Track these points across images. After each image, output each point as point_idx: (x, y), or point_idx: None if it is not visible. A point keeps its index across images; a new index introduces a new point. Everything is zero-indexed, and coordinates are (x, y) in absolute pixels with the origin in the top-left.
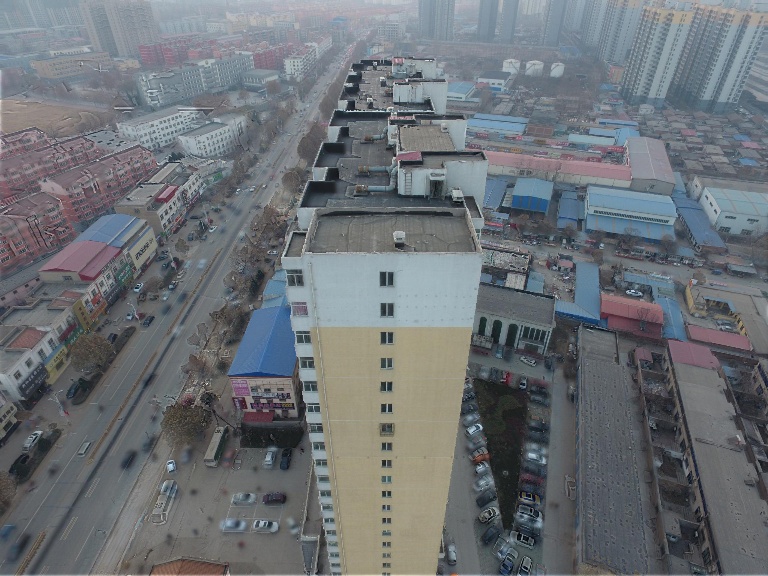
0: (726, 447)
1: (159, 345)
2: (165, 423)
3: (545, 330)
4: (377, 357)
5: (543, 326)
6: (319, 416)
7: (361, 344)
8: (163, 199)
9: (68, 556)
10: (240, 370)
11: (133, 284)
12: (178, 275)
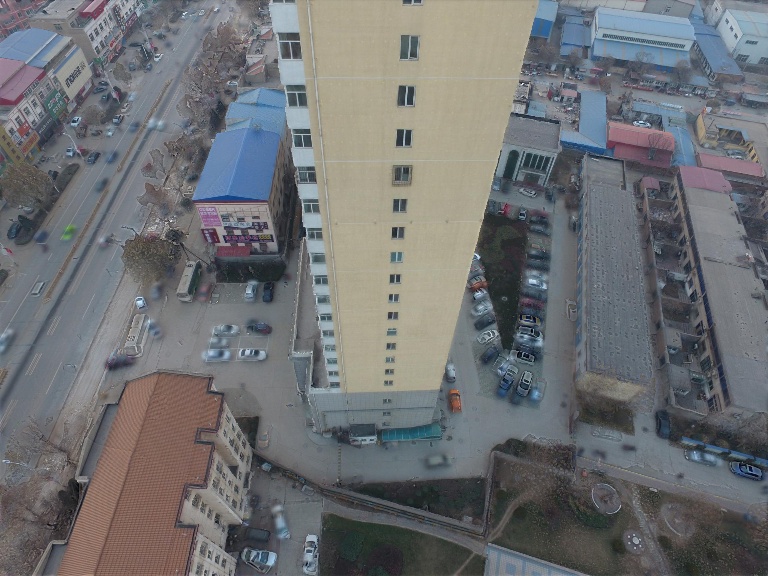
0: (735, 264)
1: (110, 183)
2: (126, 255)
3: (549, 156)
4: (396, 33)
5: (547, 151)
6: (310, 153)
7: (373, 3)
8: (89, 13)
9: (37, 390)
10: (206, 194)
11: (69, 118)
12: (122, 108)
